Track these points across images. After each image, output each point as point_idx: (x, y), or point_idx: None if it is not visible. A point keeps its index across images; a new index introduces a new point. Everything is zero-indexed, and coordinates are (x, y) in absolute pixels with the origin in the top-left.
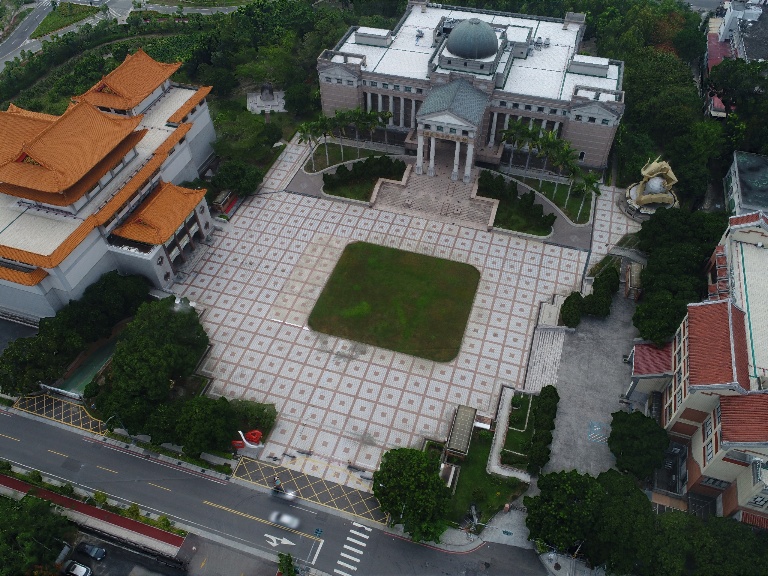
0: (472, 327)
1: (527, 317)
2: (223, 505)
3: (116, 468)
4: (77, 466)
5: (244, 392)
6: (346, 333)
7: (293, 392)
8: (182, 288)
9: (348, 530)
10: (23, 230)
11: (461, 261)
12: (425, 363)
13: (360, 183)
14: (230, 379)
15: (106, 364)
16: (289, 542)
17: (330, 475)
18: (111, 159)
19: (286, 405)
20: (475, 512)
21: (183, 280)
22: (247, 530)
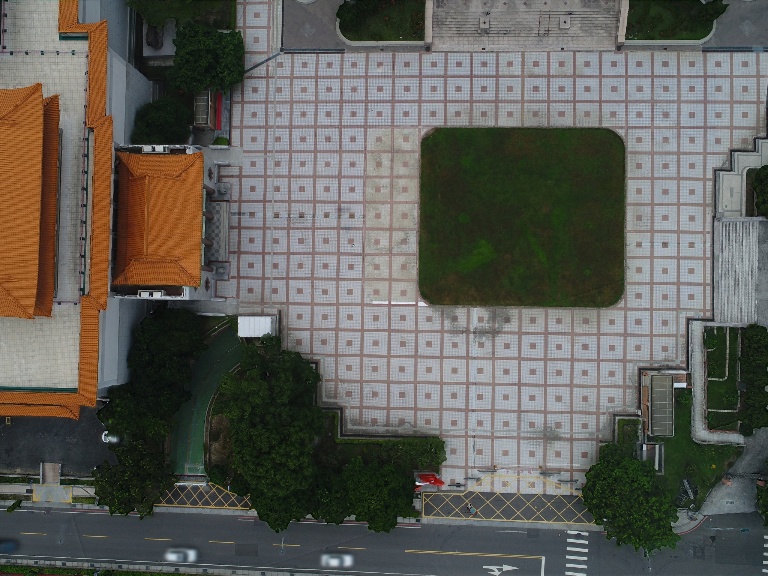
0: (633, 241)
1: (701, 202)
2: (427, 549)
3: (295, 541)
4: (252, 550)
5: (387, 416)
6: (476, 297)
7: (444, 399)
8: (231, 286)
9: (565, 540)
10: (1, 348)
11: (592, 125)
12: (587, 314)
13: (396, 3)
14: (362, 403)
15: (207, 428)
16: (511, 568)
17: (525, 487)
18: (44, 189)
19: (443, 418)
20: (688, 486)
21: (226, 274)
22: (464, 567)
